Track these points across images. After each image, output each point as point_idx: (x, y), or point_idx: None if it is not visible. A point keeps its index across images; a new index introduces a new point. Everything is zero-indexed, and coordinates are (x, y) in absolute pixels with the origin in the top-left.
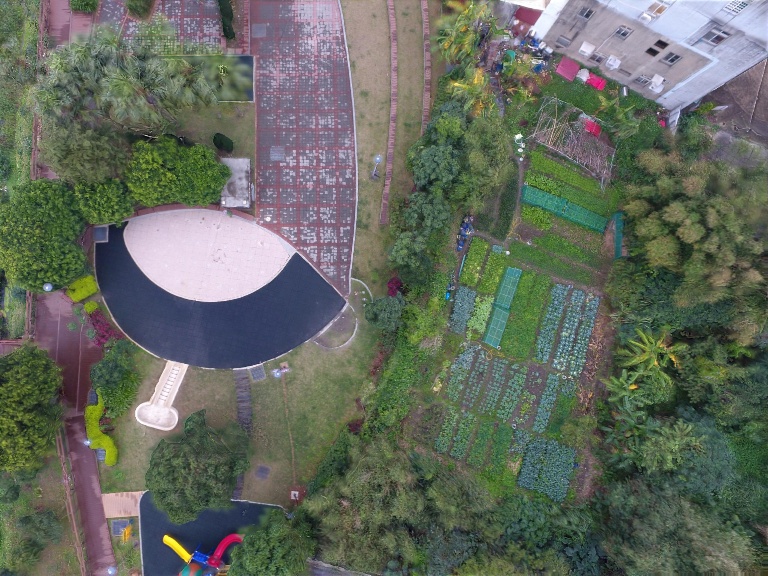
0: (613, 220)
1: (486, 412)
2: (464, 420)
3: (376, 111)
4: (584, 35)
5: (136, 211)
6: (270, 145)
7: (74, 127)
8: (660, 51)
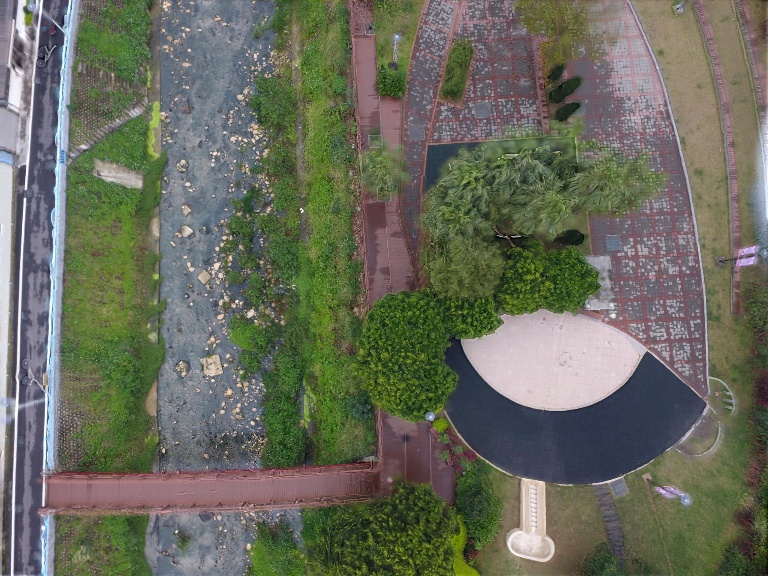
0: None
1: None
2: None
3: (713, 191)
4: None
5: None
6: (605, 234)
7: (477, 244)
8: None
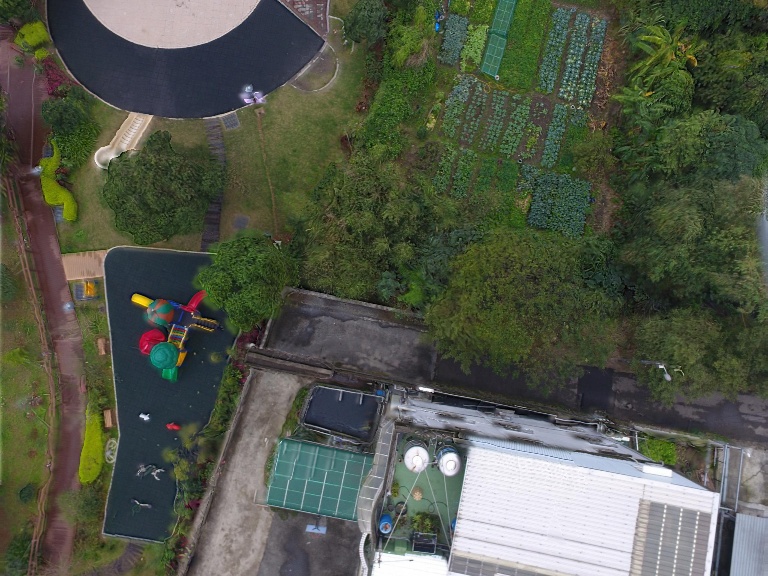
0: None
1: (487, 148)
2: (463, 156)
3: None
4: None
5: None
6: None
7: None
8: None
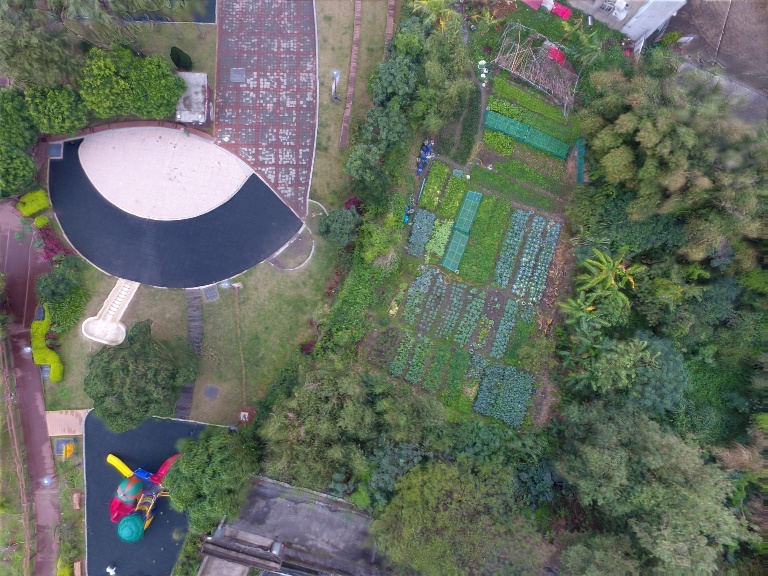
0: (575, 147)
1: (443, 336)
2: (420, 344)
3: (339, 36)
4: None
5: (92, 127)
6: (231, 66)
7: (22, 24)
8: None
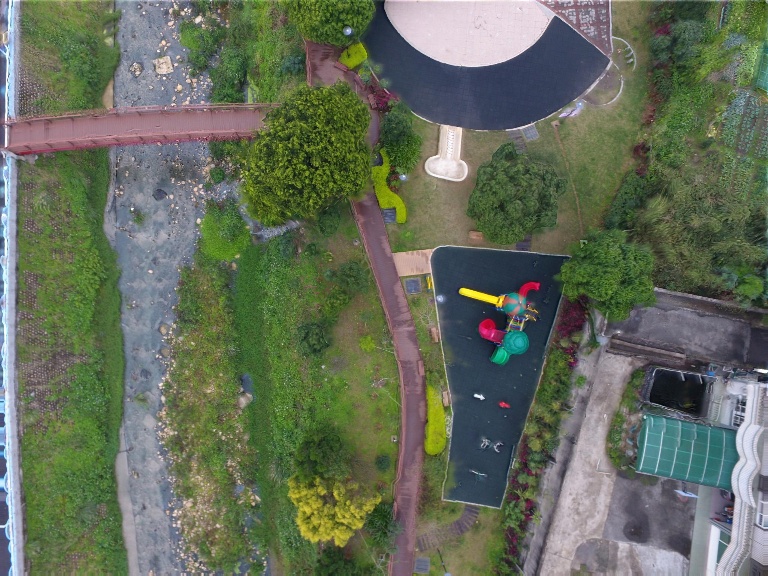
0: None
1: (762, 156)
2: (742, 164)
3: None
4: None
5: None
6: None
7: None
8: None
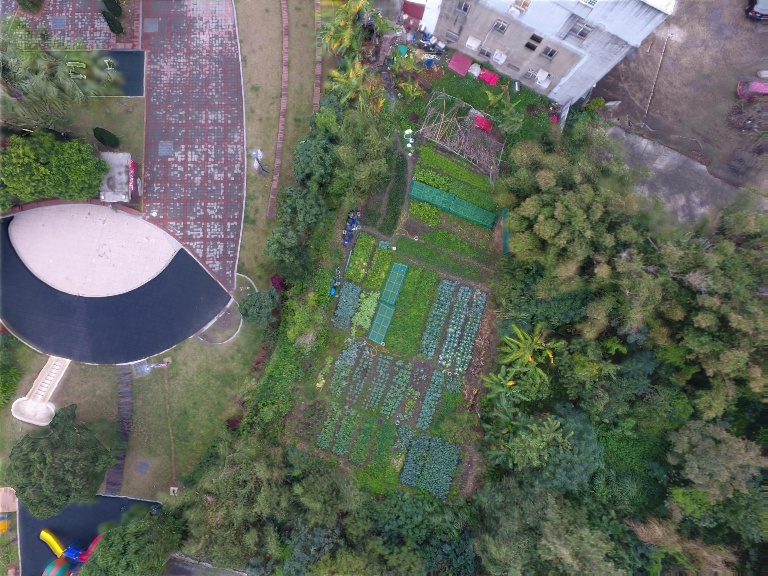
0: (501, 216)
1: (369, 408)
2: (347, 416)
3: (266, 106)
4: (468, 29)
5: (21, 206)
6: (159, 140)
7: None
8: (538, 45)
